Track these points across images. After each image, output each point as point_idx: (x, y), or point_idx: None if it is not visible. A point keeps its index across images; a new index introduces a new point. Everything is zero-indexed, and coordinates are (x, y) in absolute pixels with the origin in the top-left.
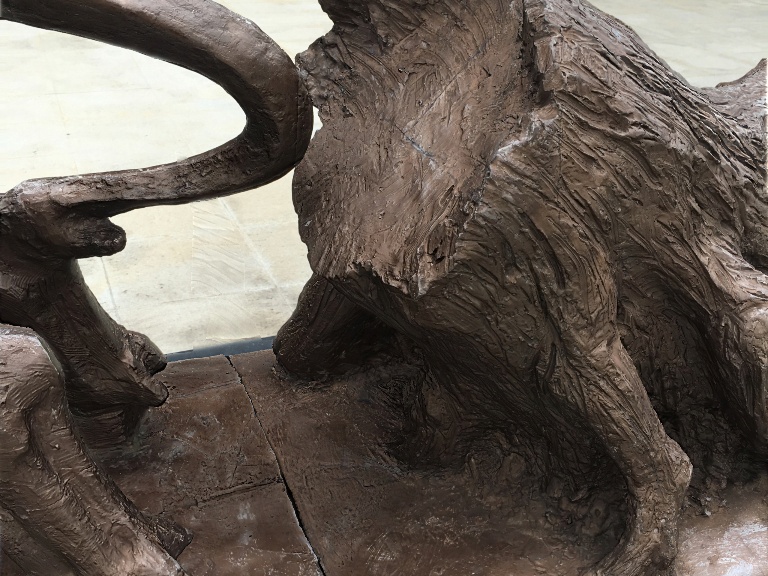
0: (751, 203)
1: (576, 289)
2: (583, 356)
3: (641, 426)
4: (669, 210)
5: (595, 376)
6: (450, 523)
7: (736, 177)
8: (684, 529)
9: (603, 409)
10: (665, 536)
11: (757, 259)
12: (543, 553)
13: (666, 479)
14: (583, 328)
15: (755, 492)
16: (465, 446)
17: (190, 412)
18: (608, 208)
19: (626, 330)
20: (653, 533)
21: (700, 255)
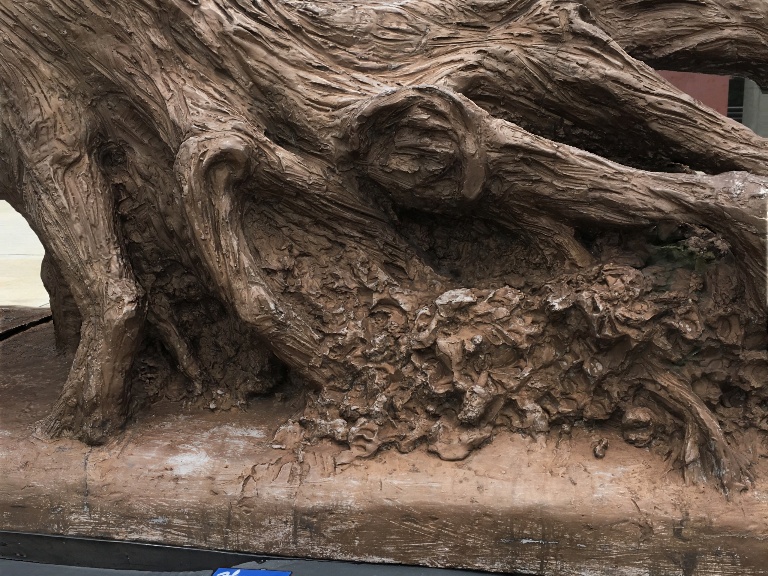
0: (257, 57)
1: (16, 98)
2: (31, 169)
3: (76, 248)
4: (127, 42)
5: (40, 190)
6: (26, 379)
7: (223, 23)
8: (179, 414)
9: (44, 224)
10: (88, 375)
11: (293, 129)
12: (46, 402)
13: (101, 314)
14: (29, 140)
15: (291, 408)
16: (77, 321)
17: (6, 314)
18: (51, 29)
19: (128, 177)
20: (81, 371)
21: (165, 91)
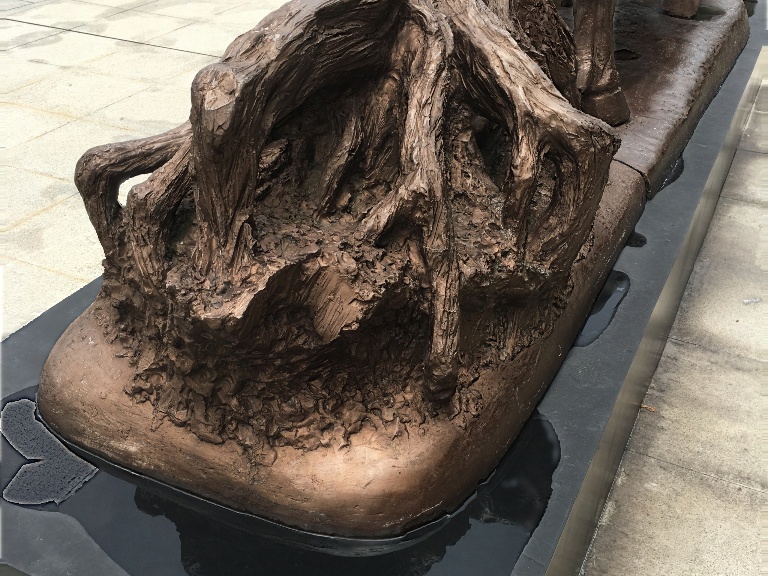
0: None
1: None
2: None
3: None
4: None
5: None
6: None
7: None
8: None
9: None
10: None
11: None
12: None
13: None
14: None
15: None
16: None
17: None
18: None
19: None
20: None
21: None
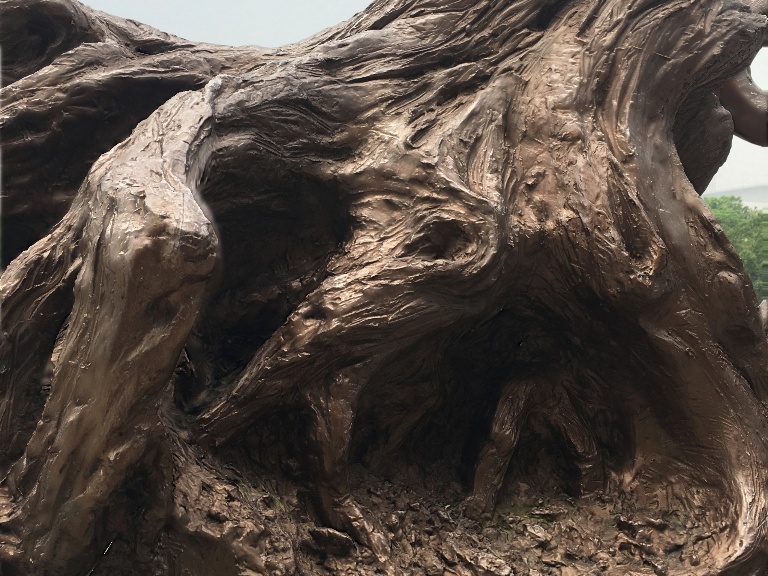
0: None
1: None
2: None
3: None
4: None
5: None
6: None
7: None
8: None
9: None
10: None
11: None
12: None
13: None
14: None
15: None
16: None
17: None
18: None
19: None
20: None
21: None
